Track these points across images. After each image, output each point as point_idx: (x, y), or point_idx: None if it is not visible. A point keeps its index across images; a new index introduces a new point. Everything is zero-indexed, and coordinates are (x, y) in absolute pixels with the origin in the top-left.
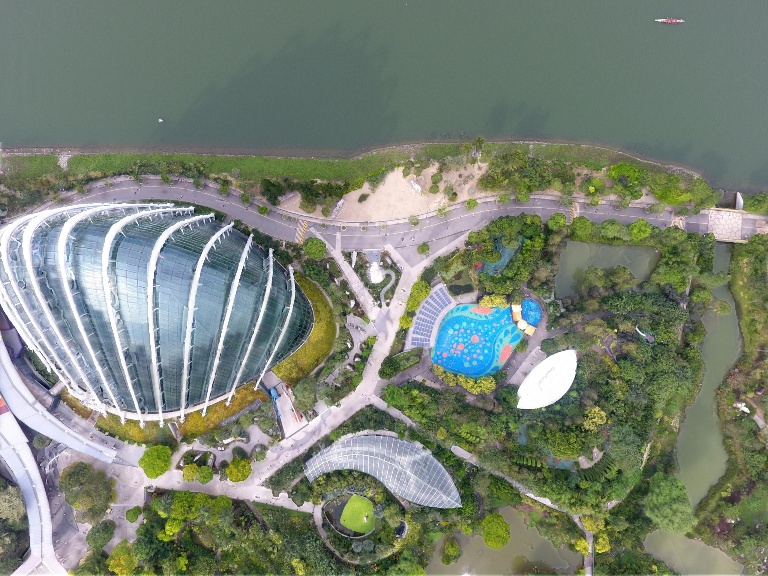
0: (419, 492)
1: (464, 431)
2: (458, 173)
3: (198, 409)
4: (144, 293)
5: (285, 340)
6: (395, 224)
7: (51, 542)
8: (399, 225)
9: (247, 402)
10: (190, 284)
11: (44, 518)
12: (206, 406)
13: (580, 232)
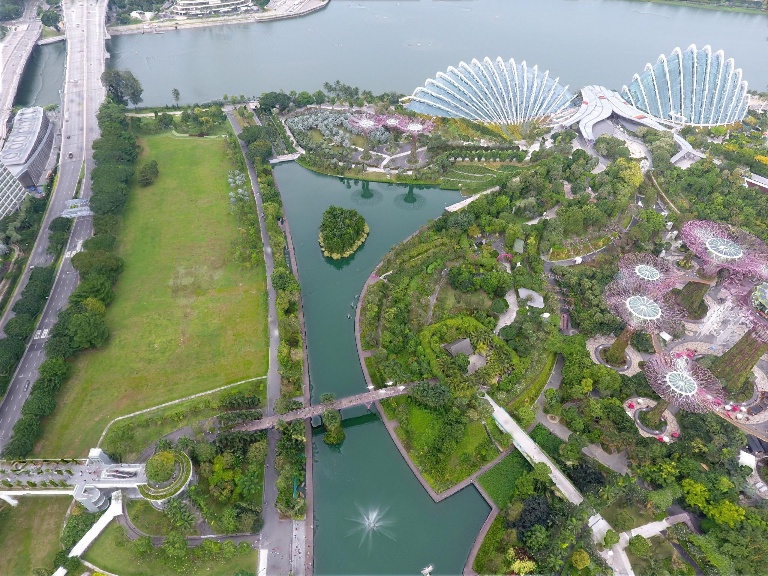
0: None
1: None
2: None
3: (722, 125)
4: (718, 62)
5: None
6: (754, 105)
7: (690, 145)
8: (756, 105)
9: (739, 127)
10: None
11: None
12: (726, 122)
13: None
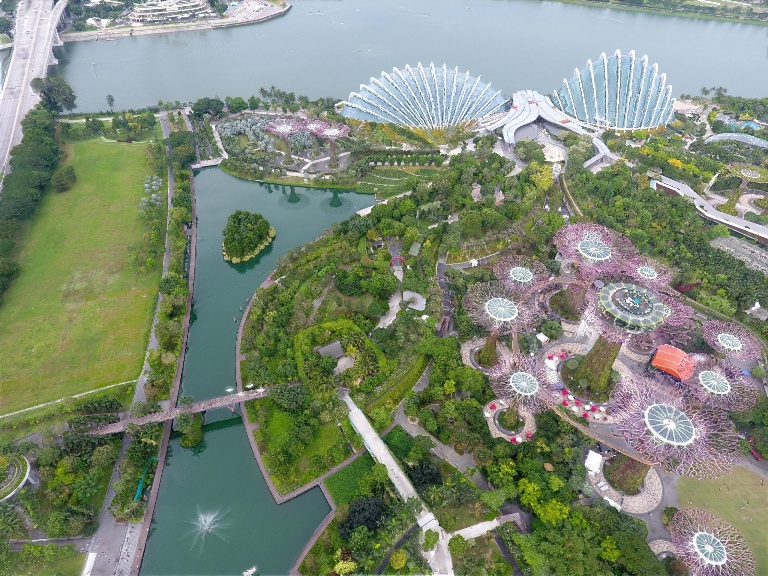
0: (762, 144)
1: (766, 132)
2: (701, 101)
3: (646, 128)
4: (641, 67)
5: (672, 113)
6: (686, 109)
7: None
8: (688, 109)
9: None
10: (652, 70)
11: (600, 144)
12: None
13: (765, 102)
